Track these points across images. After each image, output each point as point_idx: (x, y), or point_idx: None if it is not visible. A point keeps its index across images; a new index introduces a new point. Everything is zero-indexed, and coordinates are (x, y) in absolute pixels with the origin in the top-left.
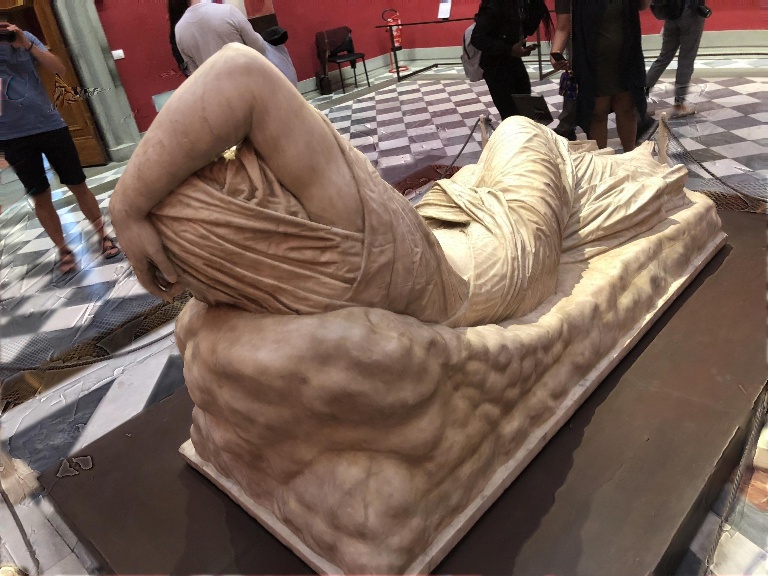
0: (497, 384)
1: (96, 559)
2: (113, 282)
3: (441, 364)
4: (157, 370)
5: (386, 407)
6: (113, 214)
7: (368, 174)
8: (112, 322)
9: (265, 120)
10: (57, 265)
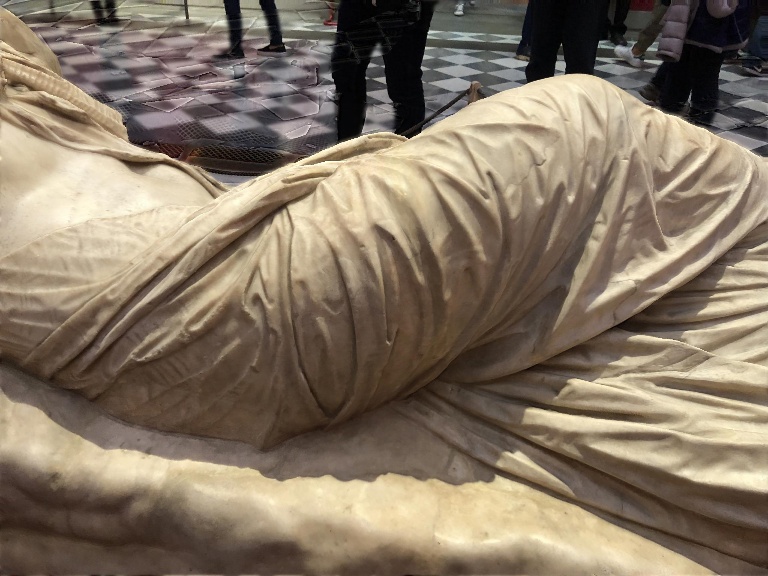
0: None
1: None
2: (188, 83)
3: None
4: None
5: None
6: None
7: None
8: (193, 128)
9: None
10: (161, 39)
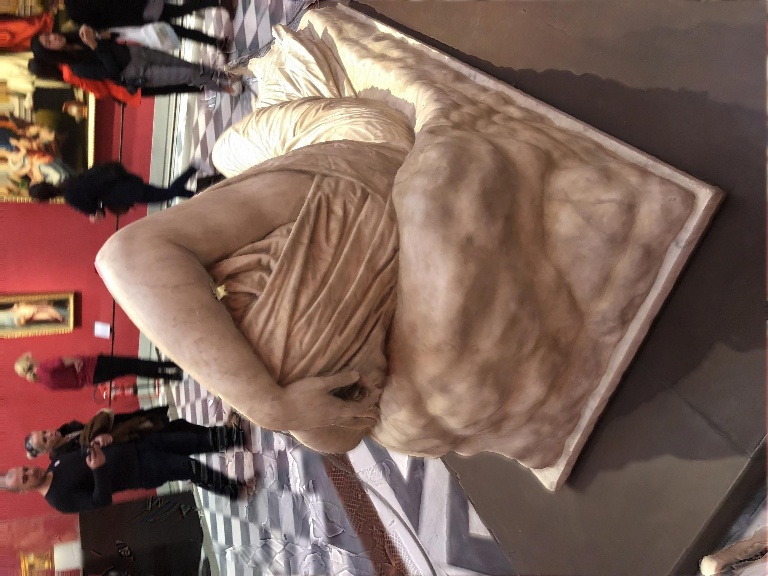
0: (473, 109)
1: (684, 574)
2: None
3: (452, 129)
4: (464, 574)
5: (496, 165)
6: (275, 417)
7: (254, 169)
8: None
9: (185, 234)
10: None
